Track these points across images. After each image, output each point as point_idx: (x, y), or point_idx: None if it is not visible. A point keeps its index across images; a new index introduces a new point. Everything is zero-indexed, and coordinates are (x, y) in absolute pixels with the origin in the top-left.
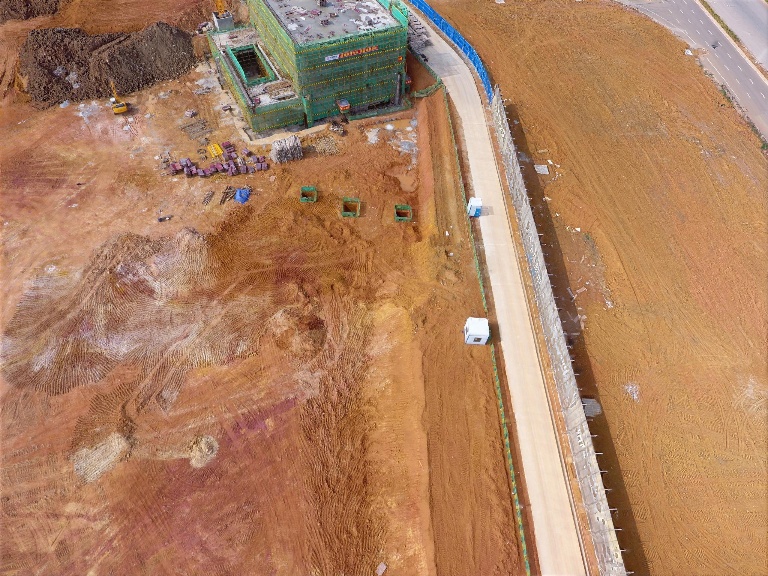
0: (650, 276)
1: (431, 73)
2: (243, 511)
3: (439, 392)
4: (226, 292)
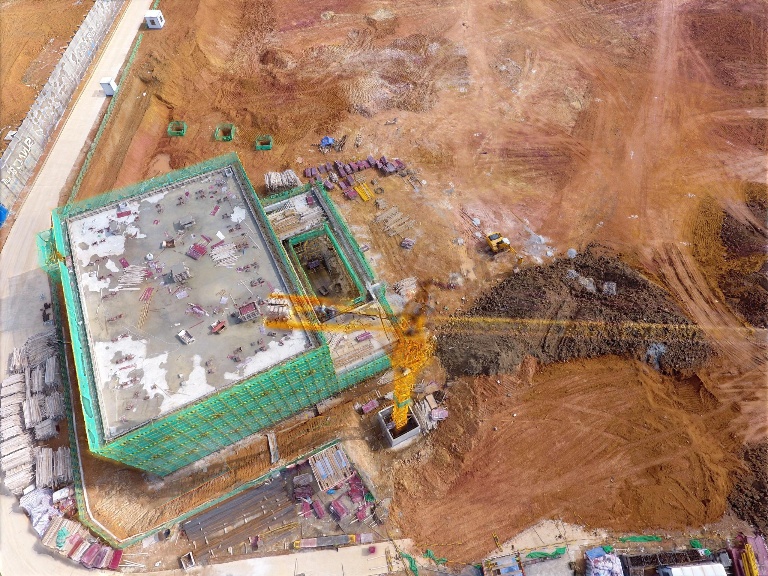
0: (3, 51)
1: (54, 276)
2: (306, 1)
3: (191, 3)
4: (330, 79)
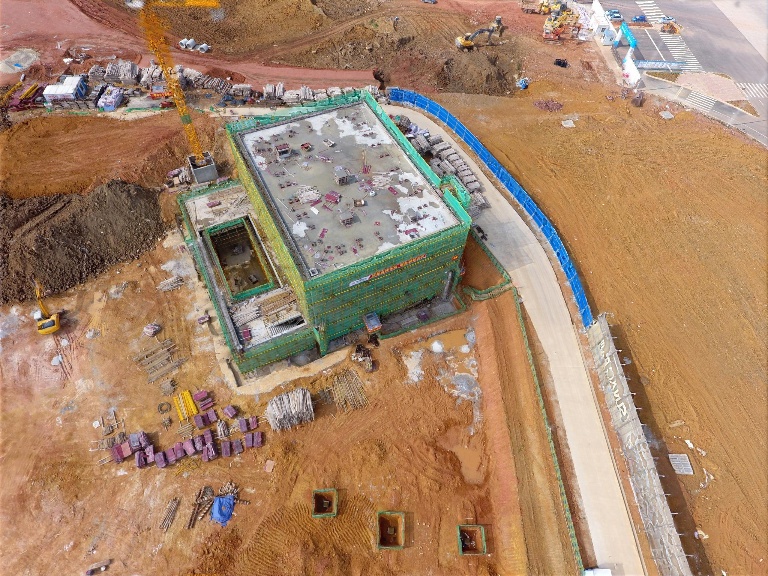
0: None
1: (494, 262)
2: None
3: None
4: None
